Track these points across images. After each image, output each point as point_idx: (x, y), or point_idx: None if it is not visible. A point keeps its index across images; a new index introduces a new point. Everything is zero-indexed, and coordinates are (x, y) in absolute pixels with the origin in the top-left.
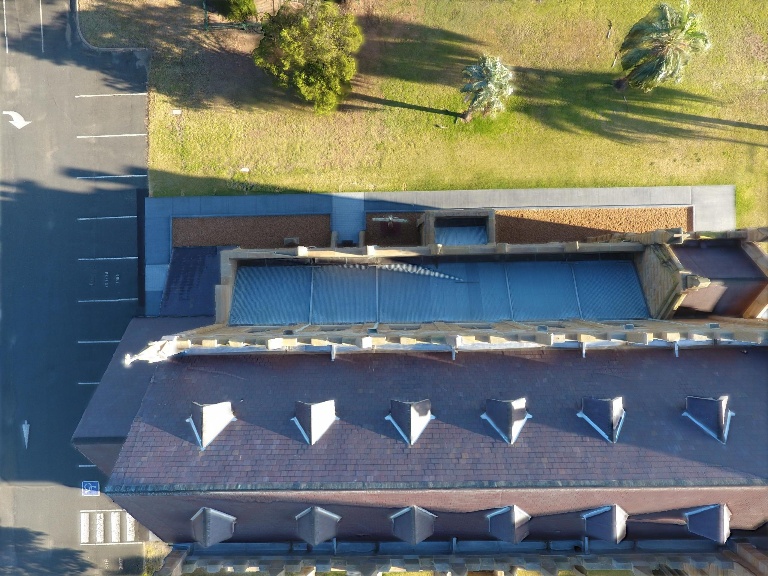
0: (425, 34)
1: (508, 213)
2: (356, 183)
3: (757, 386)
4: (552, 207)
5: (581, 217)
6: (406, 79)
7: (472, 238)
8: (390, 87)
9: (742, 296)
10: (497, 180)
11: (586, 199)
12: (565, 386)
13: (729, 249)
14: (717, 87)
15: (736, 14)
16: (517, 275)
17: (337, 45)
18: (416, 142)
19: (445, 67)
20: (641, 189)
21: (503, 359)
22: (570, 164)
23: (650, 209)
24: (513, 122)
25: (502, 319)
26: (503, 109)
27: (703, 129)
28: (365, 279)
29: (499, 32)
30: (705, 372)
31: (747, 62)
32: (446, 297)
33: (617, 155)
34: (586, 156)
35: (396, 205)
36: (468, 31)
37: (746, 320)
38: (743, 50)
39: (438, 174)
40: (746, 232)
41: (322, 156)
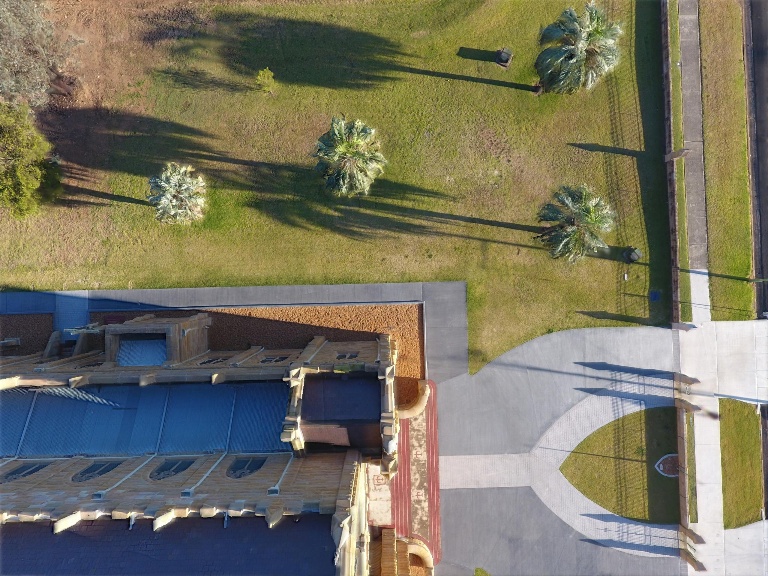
0: (155, 127)
1: (236, 311)
2: (80, 281)
3: (280, 567)
4: (280, 305)
5: (310, 315)
6: (134, 173)
7: (157, 353)
8: (118, 182)
9: (369, 434)
10: (225, 277)
11: (316, 296)
12: (86, 569)
13: (368, 381)
14: (450, 182)
15: (469, 108)
16: (178, 400)
17: (13, 156)
18: (143, 238)
19: (175, 161)
20: (372, 286)
21: (46, 532)
22: (300, 261)
23: (380, 306)
24: (244, 217)
25: (145, 452)
26: (197, 217)
27: (435, 225)
28: (20, 406)
29: (231, 125)
30: (240, 548)
31: (480, 157)
32: (97, 426)
33: (349, 251)
34: (317, 252)
35: (121, 304)
36: (199, 124)
37: (344, 470)
38: (476, 144)
39: (165, 271)
40: (379, 366)
41: (46, 253)
